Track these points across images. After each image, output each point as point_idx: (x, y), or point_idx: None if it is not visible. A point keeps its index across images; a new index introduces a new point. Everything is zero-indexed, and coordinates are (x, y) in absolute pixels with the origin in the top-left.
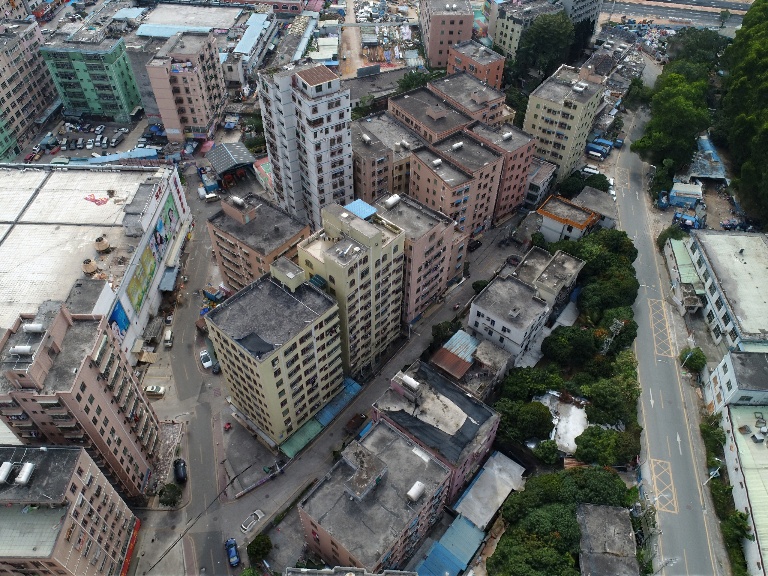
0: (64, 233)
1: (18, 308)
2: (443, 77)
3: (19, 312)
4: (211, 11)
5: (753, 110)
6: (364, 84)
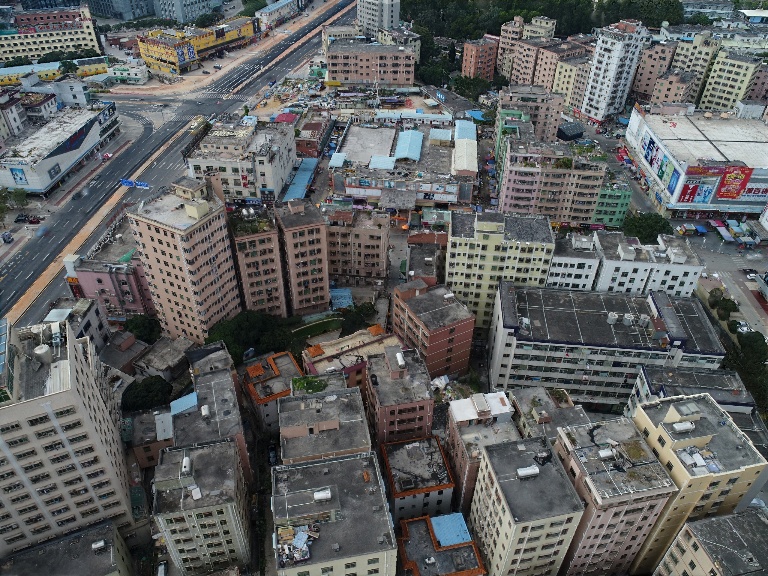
0: (705, 128)
1: (759, 130)
2: (528, 44)
3: (761, 129)
4: (356, 138)
5: (533, 6)
6: (452, 102)
